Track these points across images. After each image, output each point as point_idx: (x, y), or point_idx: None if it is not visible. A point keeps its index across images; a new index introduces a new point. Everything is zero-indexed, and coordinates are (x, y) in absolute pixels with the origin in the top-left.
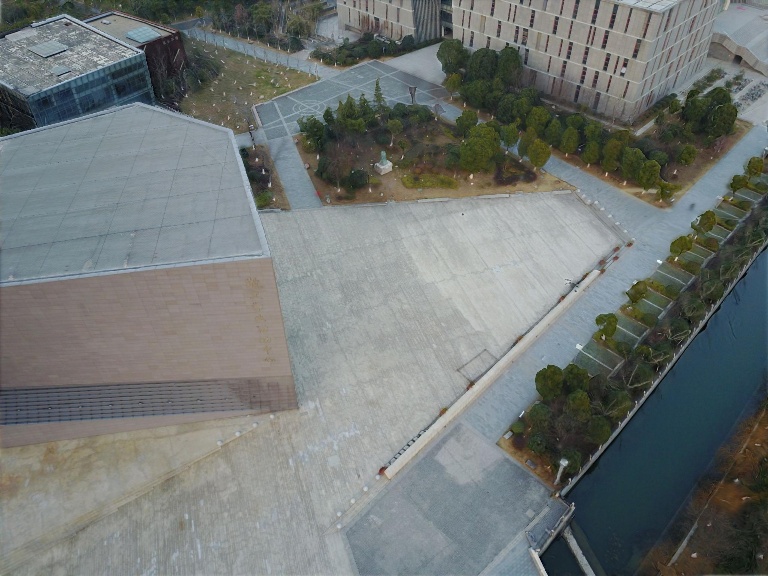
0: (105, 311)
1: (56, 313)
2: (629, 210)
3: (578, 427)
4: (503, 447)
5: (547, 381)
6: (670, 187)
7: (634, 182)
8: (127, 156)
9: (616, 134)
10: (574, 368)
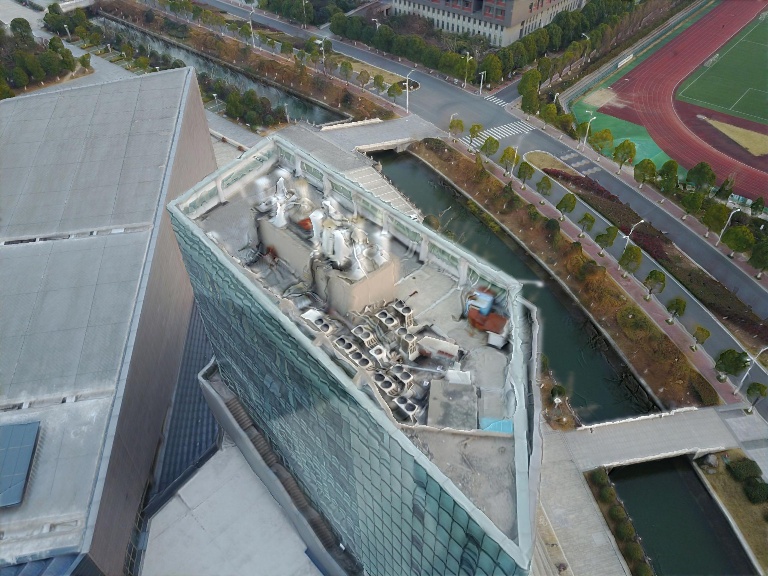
0: (188, 159)
1: (183, 177)
2: (88, 82)
3: (262, 106)
4: (265, 135)
5: (236, 104)
6: (86, 56)
7: (60, 75)
8: (1, 149)
9: (17, 56)
10: (232, 93)
